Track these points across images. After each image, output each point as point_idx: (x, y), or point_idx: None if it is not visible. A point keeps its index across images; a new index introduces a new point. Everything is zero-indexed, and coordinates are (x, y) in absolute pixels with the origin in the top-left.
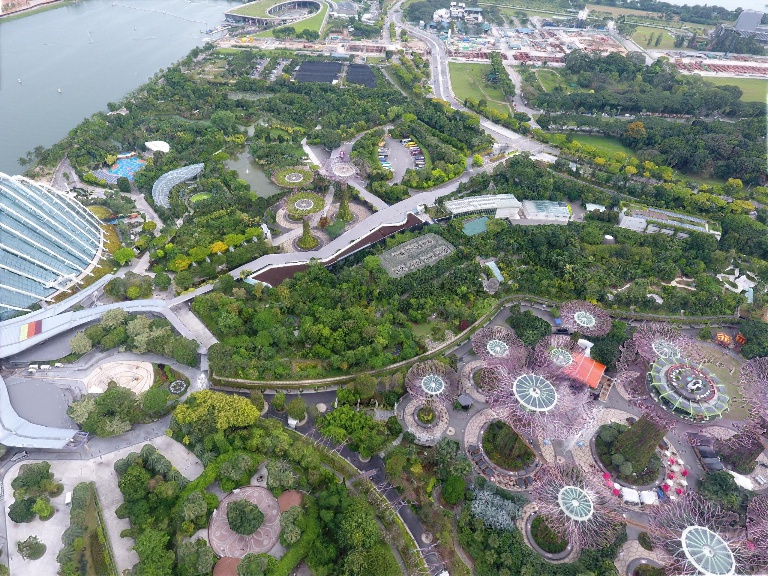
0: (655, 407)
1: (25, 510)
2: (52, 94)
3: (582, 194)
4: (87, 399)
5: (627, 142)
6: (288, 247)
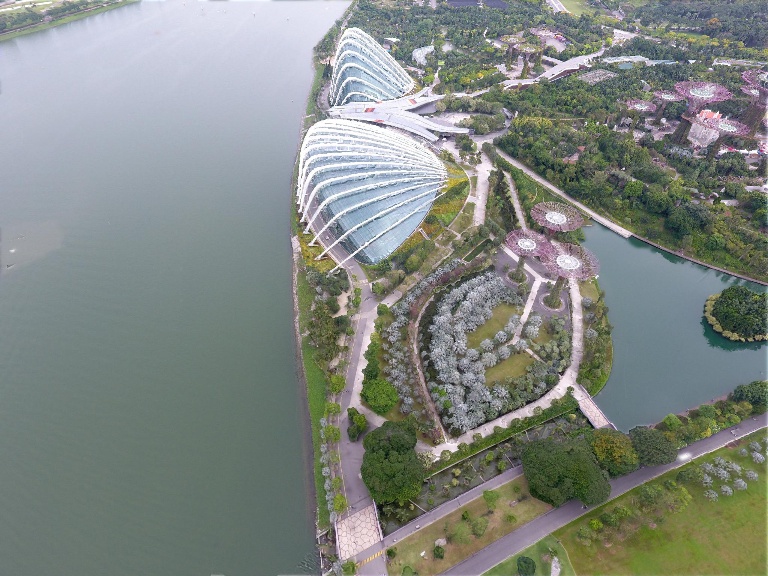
0: (759, 100)
1: None
2: (282, 21)
3: (685, 55)
4: None
5: (707, 32)
6: None
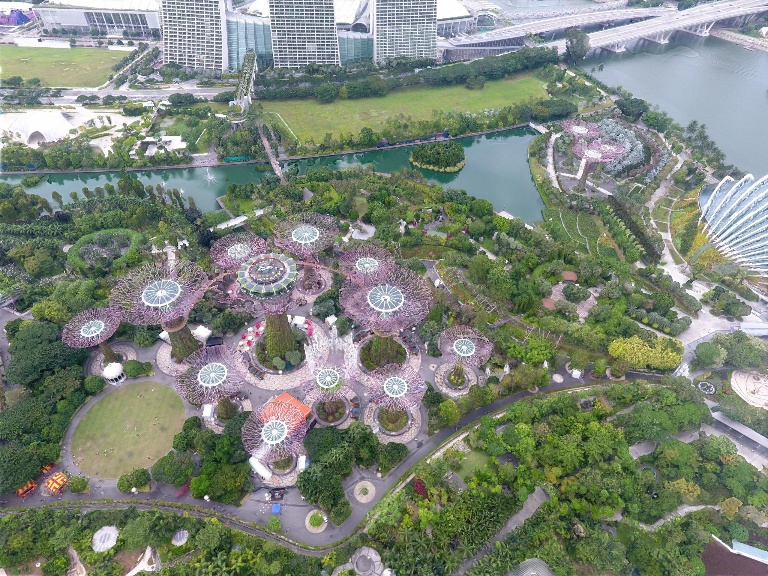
0: None
1: (716, 288)
2: None
3: None
4: (766, 351)
5: None
6: None
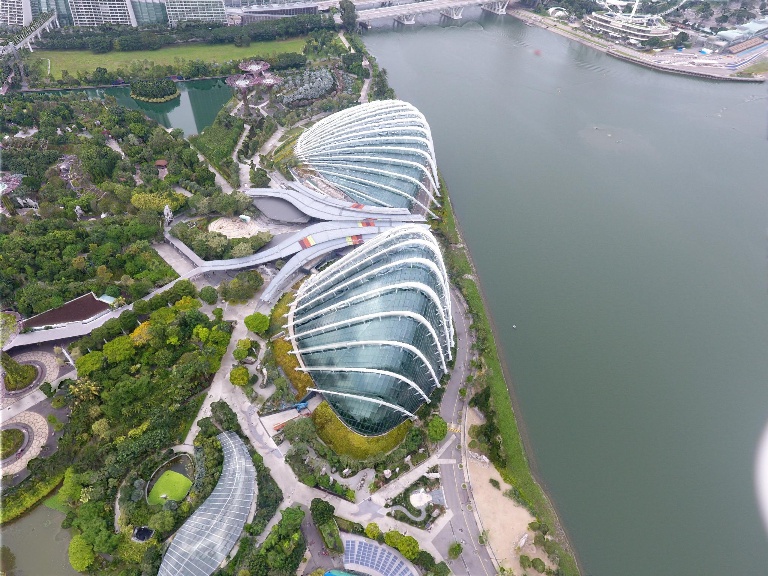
0: None
1: None
2: None
3: None
4: (242, 202)
5: None
6: (53, 370)
